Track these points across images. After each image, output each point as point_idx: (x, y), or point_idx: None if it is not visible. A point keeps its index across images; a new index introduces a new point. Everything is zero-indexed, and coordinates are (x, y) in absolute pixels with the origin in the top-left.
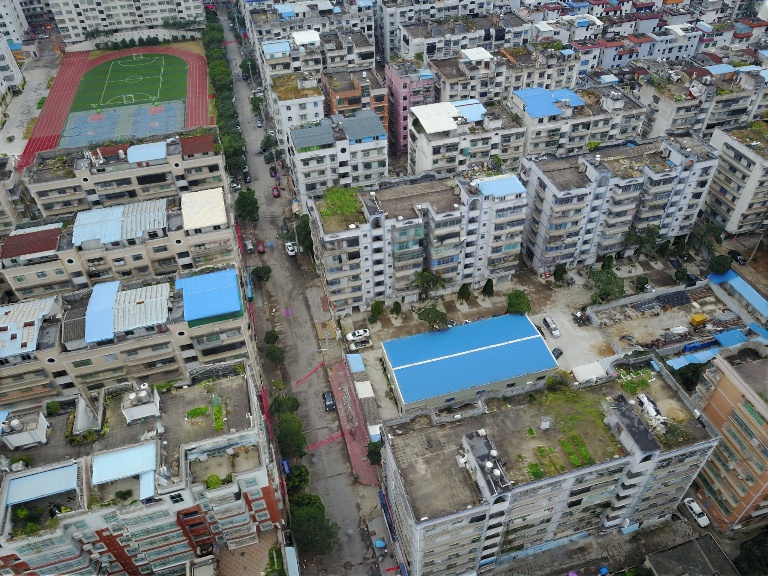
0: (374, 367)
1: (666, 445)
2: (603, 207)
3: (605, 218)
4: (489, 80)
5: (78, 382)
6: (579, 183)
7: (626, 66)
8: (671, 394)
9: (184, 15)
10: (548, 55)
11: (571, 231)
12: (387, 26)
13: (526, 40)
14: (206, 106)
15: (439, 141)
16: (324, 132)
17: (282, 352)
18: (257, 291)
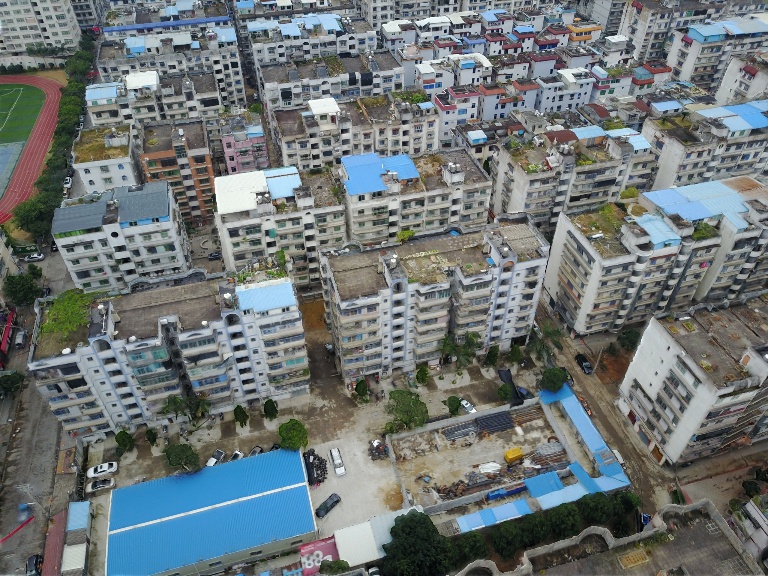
0: (107, 517)
1: None
2: (408, 314)
3: (414, 325)
4: (333, 138)
5: None
6: (372, 289)
7: (503, 118)
8: None
9: (51, 41)
10: (402, 110)
11: (369, 342)
12: (255, 63)
13: (399, 85)
14: (45, 151)
15: (235, 223)
16: (95, 212)
17: None
18: (7, 402)
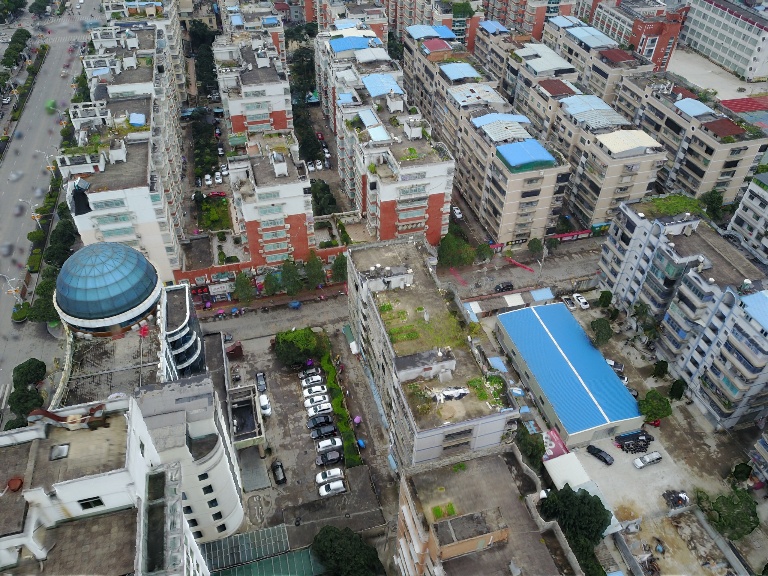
0: None
1: (412, 393)
2: None
3: None
4: None
5: None
6: None
7: None
8: (472, 415)
9: None
10: None
11: None
12: None
13: None
14: None
15: None
16: None
17: (538, 249)
18: None
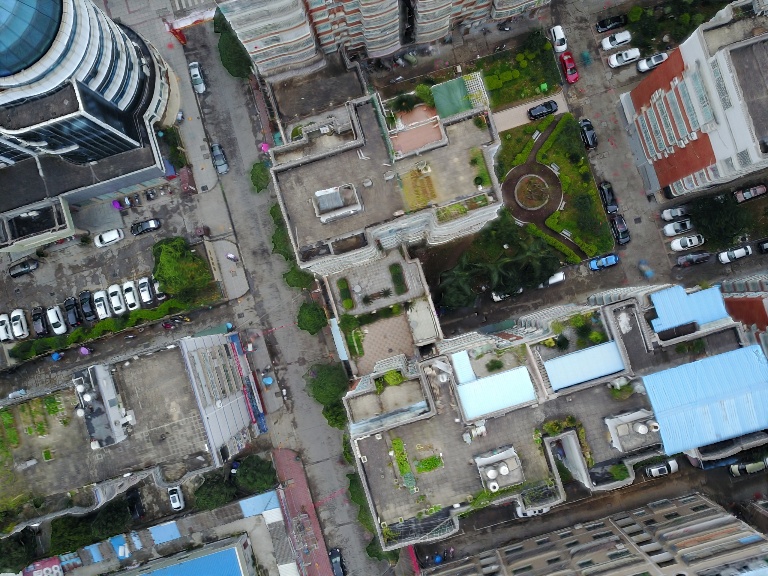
0: None
1: None
2: None
3: None
4: None
5: (642, 557)
6: None
7: None
8: None
9: None
10: None
11: None
12: None
13: None
14: None
15: None
16: None
17: None
18: None
